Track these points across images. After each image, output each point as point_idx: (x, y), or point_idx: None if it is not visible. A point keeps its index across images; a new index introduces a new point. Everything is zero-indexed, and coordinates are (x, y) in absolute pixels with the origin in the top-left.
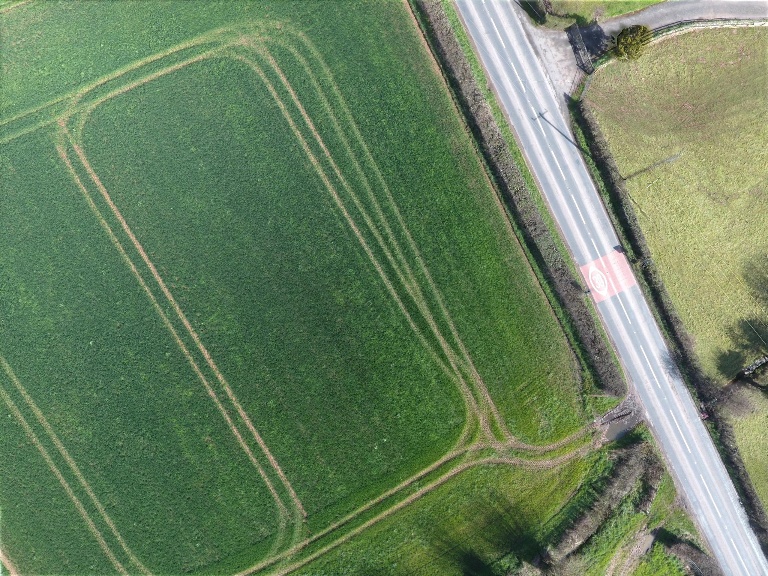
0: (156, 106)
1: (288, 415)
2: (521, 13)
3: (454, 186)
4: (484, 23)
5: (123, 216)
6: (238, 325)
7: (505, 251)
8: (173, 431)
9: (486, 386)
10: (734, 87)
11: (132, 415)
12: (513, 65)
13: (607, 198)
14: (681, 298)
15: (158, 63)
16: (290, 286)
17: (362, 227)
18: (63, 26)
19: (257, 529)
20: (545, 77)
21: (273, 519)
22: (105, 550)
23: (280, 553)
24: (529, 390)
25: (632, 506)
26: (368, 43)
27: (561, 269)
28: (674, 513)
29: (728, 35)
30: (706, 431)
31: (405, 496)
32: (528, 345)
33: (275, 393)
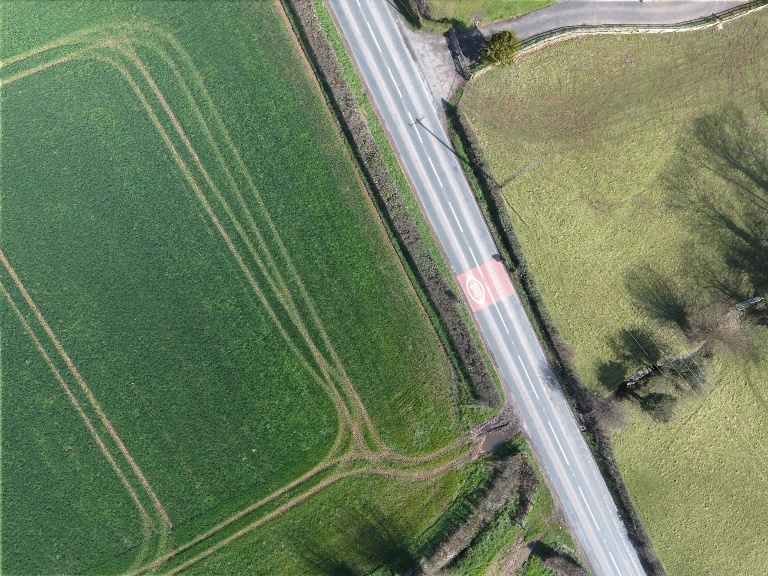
0: (18, 108)
1: (153, 424)
2: (398, 17)
3: (327, 192)
4: (360, 27)
5: None
6: (102, 332)
7: (380, 259)
8: (33, 440)
9: (360, 396)
10: (618, 94)
11: None
12: (389, 70)
13: (485, 206)
14: (561, 308)
15: (20, 64)
16: (156, 293)
17: (232, 233)
18: None
19: (121, 540)
20: (422, 82)
21: (137, 530)
22: None
23: (145, 565)
24: (404, 400)
25: (509, 519)
26: (239, 46)
27: (435, 278)
28: (551, 526)
29: (612, 42)
30: (585, 443)
31: (275, 507)
32: (403, 354)
33: (140, 402)
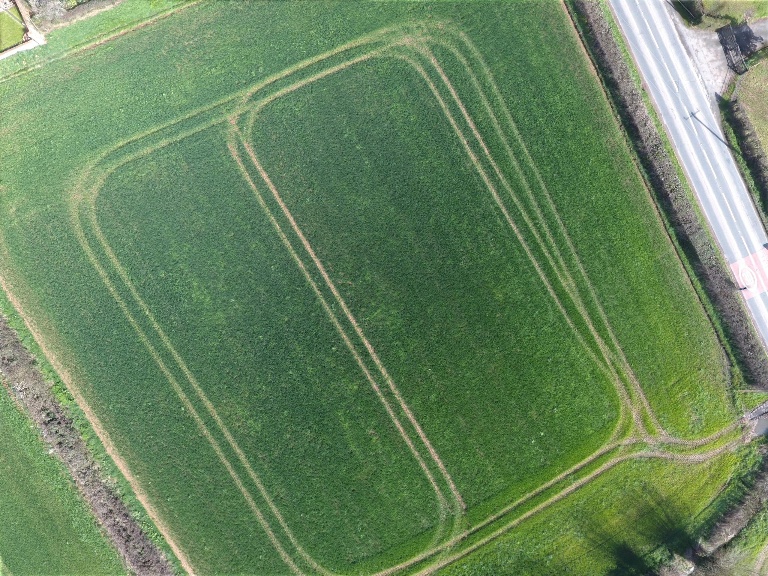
0: (323, 105)
1: (449, 409)
2: (674, 14)
3: (609, 184)
4: (638, 24)
5: (291, 213)
6: (401, 320)
7: (658, 248)
8: (339, 424)
9: (639, 381)
10: None
11: (300, 408)
12: (666, 65)
13: (757, 196)
14: None
15: (325, 63)
16: (452, 282)
17: (521, 224)
18: (234, 26)
19: (418, 521)
20: (697, 77)
21: (434, 511)
22: (272, 541)
23: (440, 544)
24: (680, 385)
25: None
26: (527, 43)
27: (715, 266)
28: None
29: None
30: None
31: (560, 489)
32: (680, 341)
33: (437, 387)
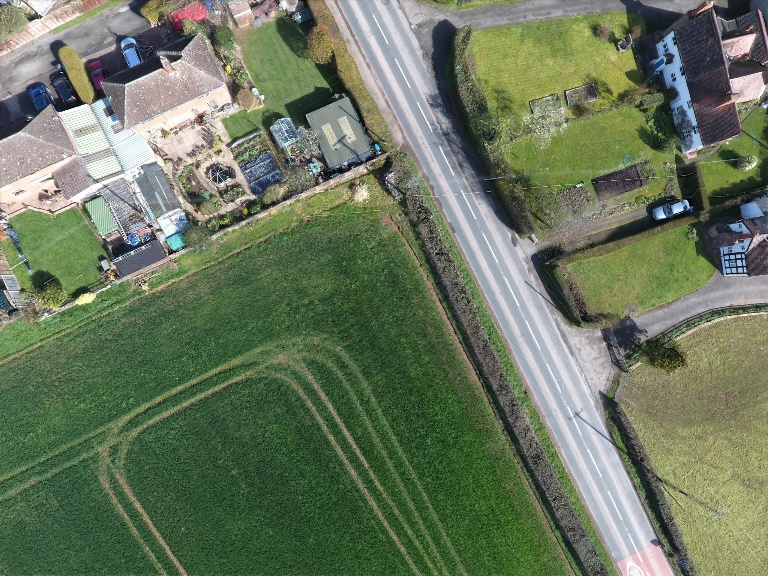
0: (197, 431)
1: None
2: (555, 314)
3: (493, 491)
4: (519, 326)
5: (167, 543)
6: None
7: (544, 552)
8: None
9: None
10: (766, 372)
11: None
12: (548, 366)
13: (643, 494)
14: None
15: (198, 388)
16: None
17: (403, 538)
18: (103, 357)
19: None
20: (580, 376)
21: None
22: None
23: None
24: None
25: None
26: (405, 354)
27: (600, 573)
28: None
29: (759, 322)
30: None
31: None
32: None
33: None
